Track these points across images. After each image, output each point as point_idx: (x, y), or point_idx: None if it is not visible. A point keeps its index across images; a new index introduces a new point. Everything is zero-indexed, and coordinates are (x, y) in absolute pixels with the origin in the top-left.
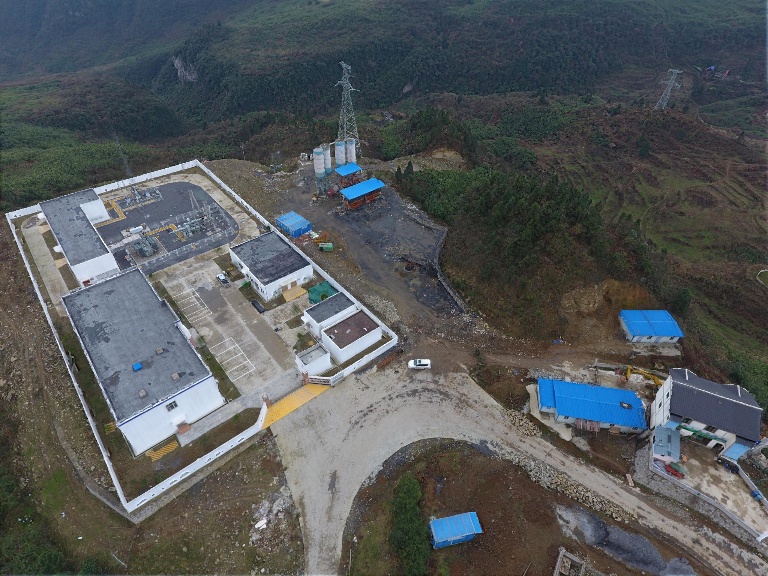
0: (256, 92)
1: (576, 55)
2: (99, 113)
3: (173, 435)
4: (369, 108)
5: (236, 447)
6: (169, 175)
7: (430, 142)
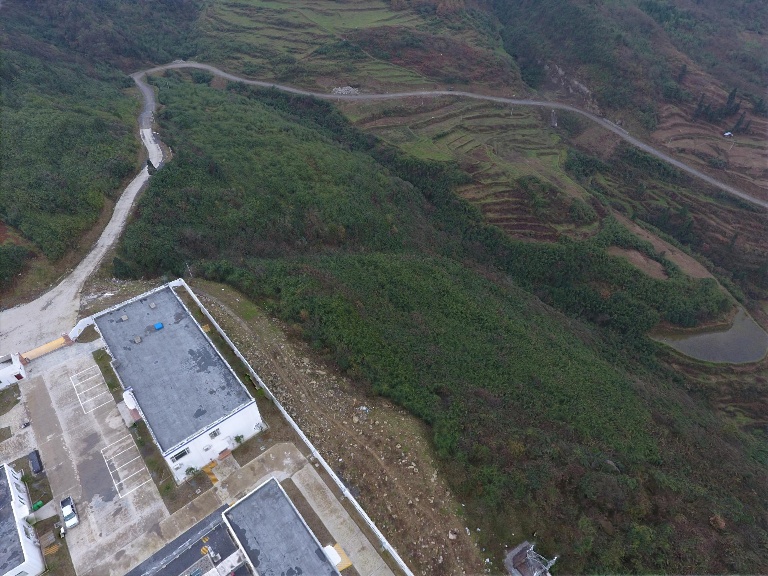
0: None
1: None
2: None
3: None
4: None
5: None
6: None
7: None
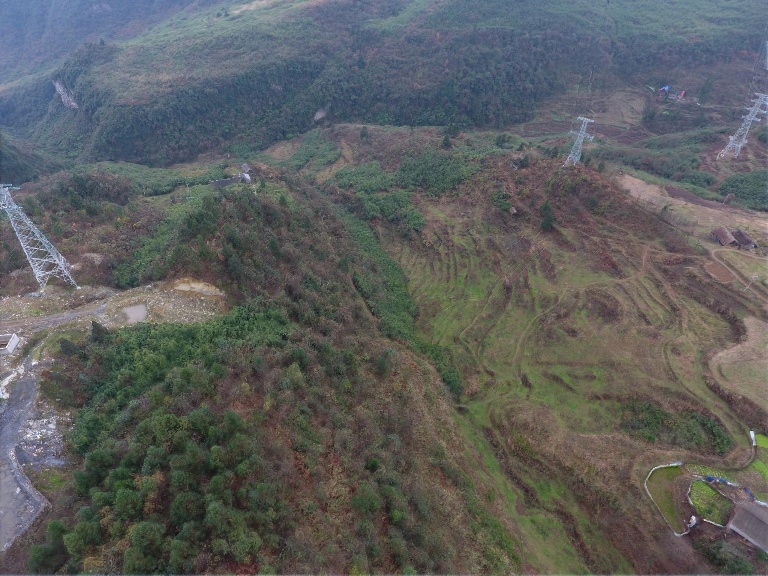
0: (130, 126)
1: (511, 75)
2: None
3: None
4: (273, 139)
5: None
6: None
7: (171, 267)
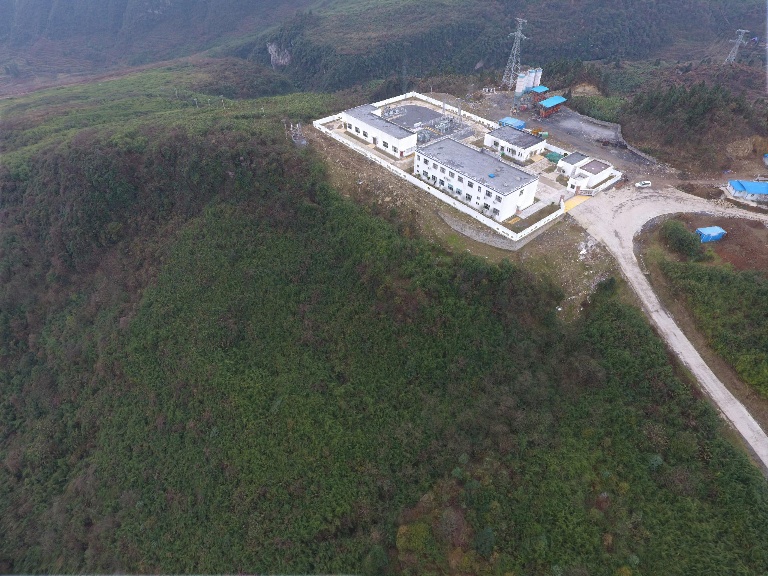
0: (354, 69)
1: (632, 31)
2: (238, 86)
3: (514, 215)
4: None
5: (554, 219)
6: (398, 101)
7: (573, 80)
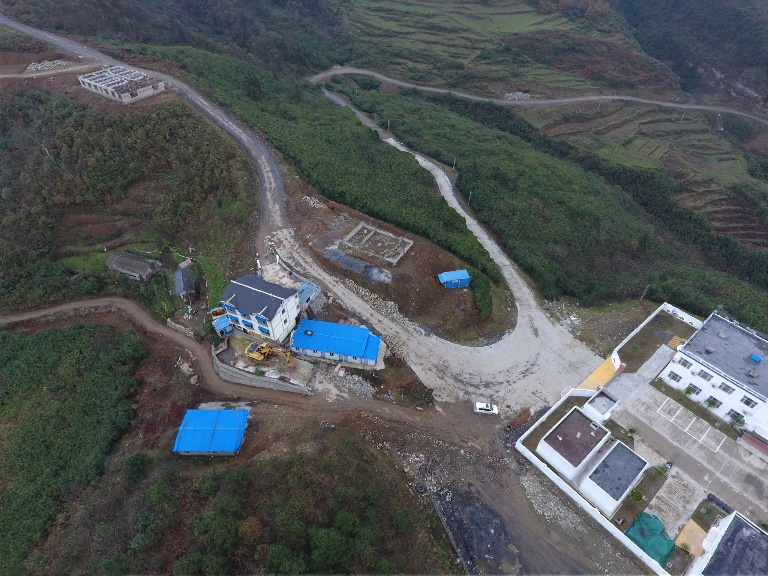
0: None
1: None
2: None
3: None
4: None
5: None
6: None
7: None
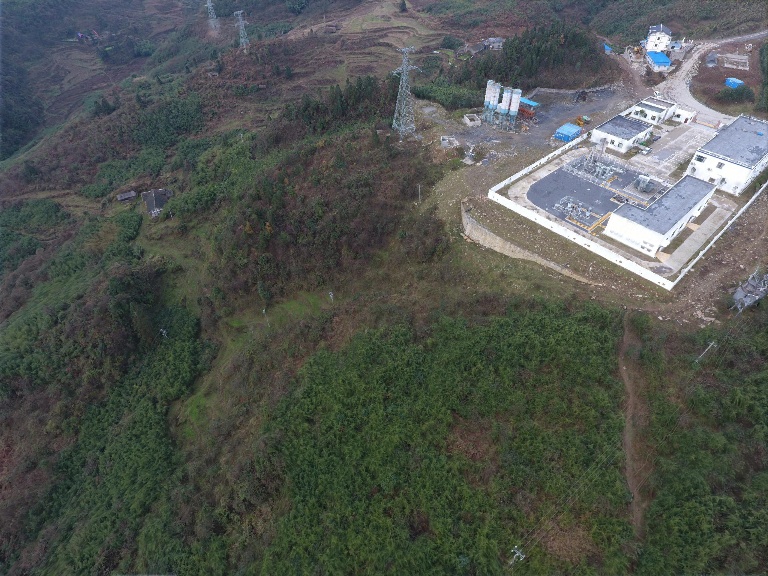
0: None
1: None
2: None
3: None
4: None
5: None
6: None
7: None
